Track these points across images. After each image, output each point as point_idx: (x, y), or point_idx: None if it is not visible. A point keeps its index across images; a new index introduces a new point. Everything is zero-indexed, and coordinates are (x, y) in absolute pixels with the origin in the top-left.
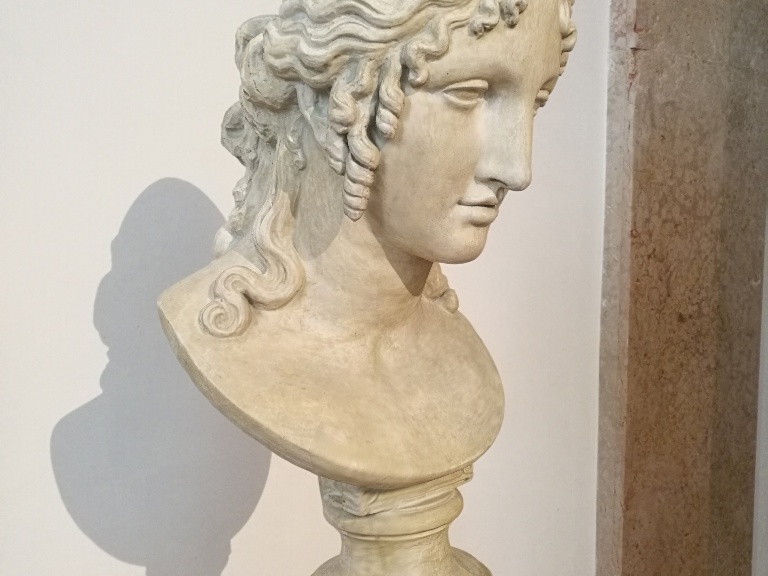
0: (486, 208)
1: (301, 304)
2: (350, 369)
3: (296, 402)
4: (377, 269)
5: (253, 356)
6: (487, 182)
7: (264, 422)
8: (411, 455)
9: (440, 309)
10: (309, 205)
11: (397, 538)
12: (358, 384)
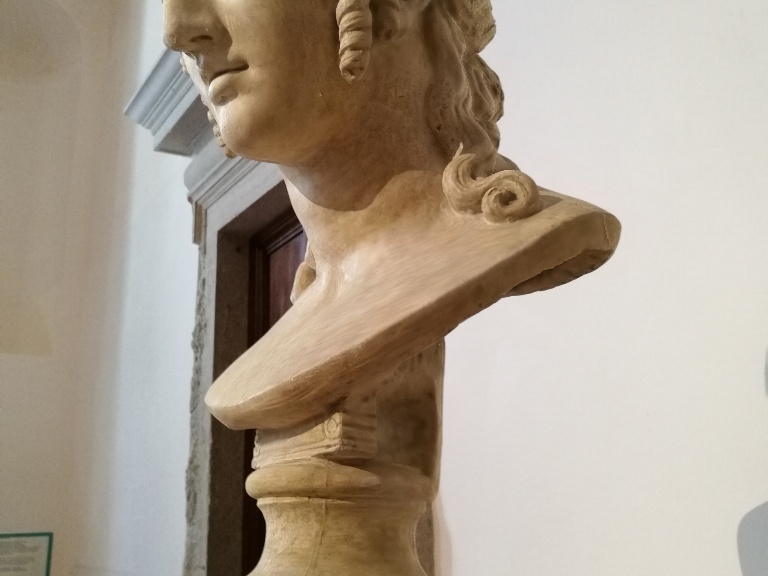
0: (213, 81)
1: None
2: None
3: None
4: None
5: None
6: (194, 58)
7: None
8: (231, 386)
9: (481, 222)
10: None
11: None
12: None
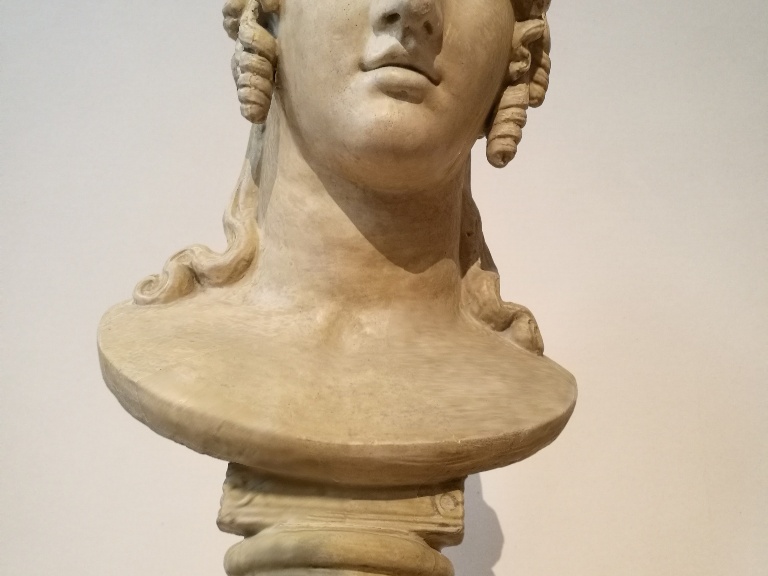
0: (400, 69)
1: (252, 279)
2: (276, 338)
3: (169, 348)
4: (317, 208)
5: (162, 317)
6: (386, 28)
7: (112, 358)
8: (284, 411)
9: (505, 341)
10: (264, 163)
11: (273, 574)
12: (273, 348)
